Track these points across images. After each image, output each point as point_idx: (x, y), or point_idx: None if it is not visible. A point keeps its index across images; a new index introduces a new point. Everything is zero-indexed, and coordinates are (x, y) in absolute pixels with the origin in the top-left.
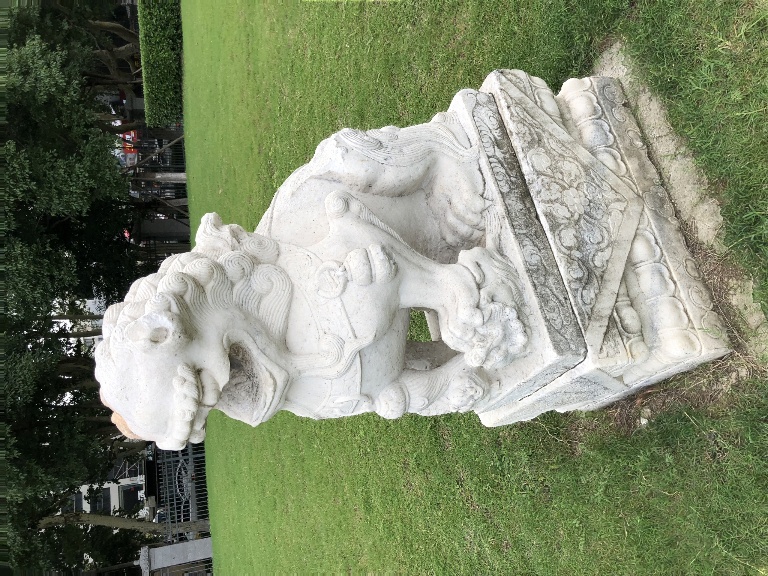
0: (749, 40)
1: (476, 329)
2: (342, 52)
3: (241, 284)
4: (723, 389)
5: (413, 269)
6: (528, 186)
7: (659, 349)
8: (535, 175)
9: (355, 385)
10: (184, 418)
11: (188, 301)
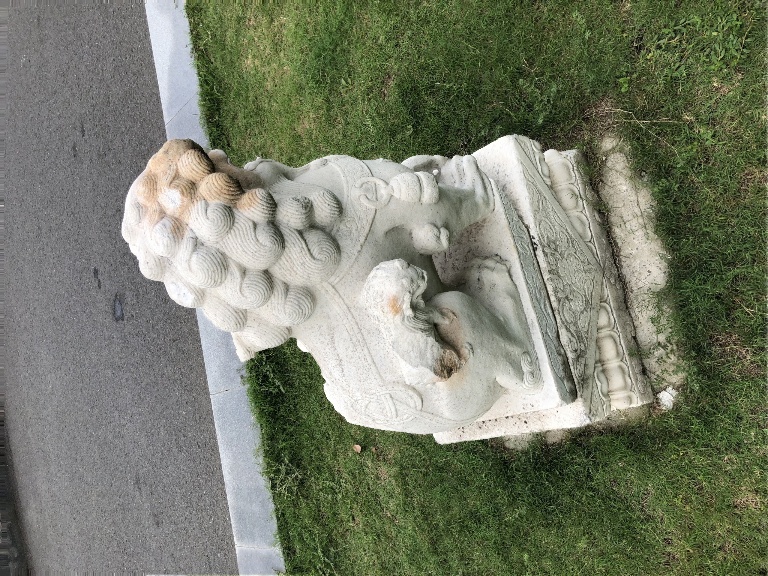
0: None
1: None
2: None
3: None
4: None
5: None
6: None
7: None
8: None
9: None
10: None
11: None
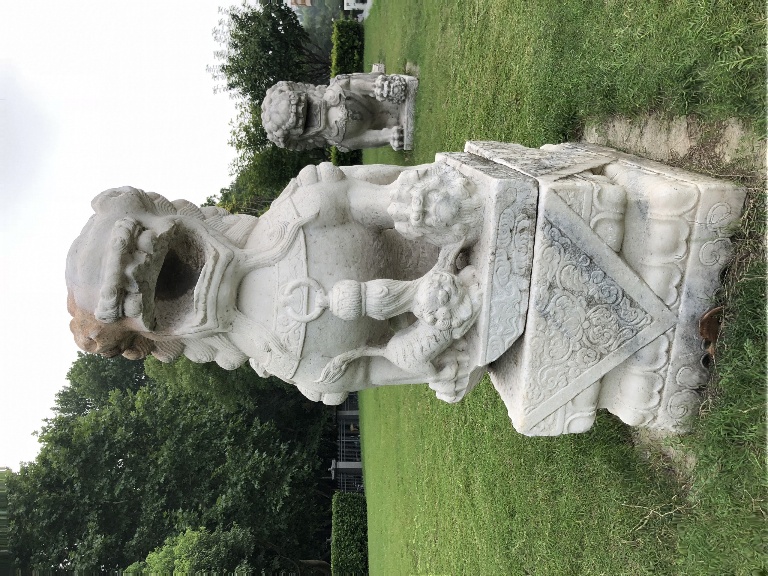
0: (633, 7)
1: (414, 186)
2: None
3: (212, 218)
4: (767, 239)
5: (363, 181)
6: (489, 159)
7: (650, 206)
8: (495, 153)
9: (301, 264)
10: (114, 244)
11: (156, 203)
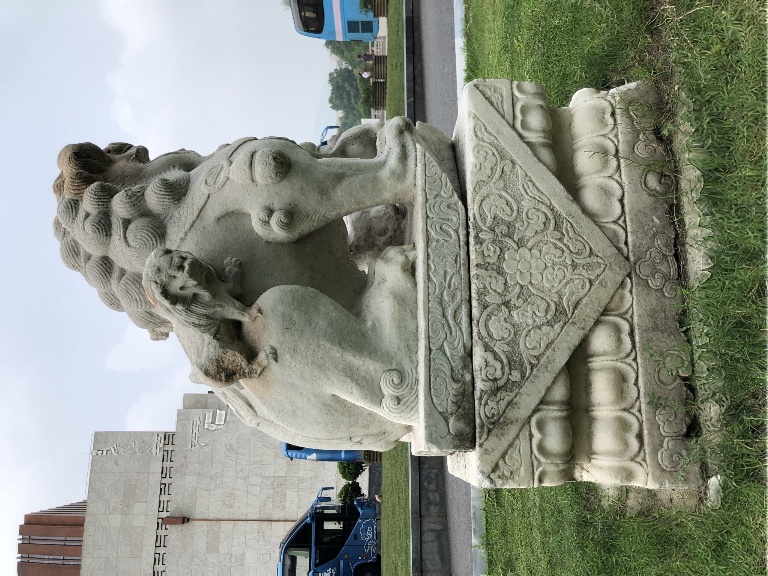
0: None
1: None
2: None
3: None
4: None
5: None
6: None
7: None
8: None
9: None
10: None
11: None
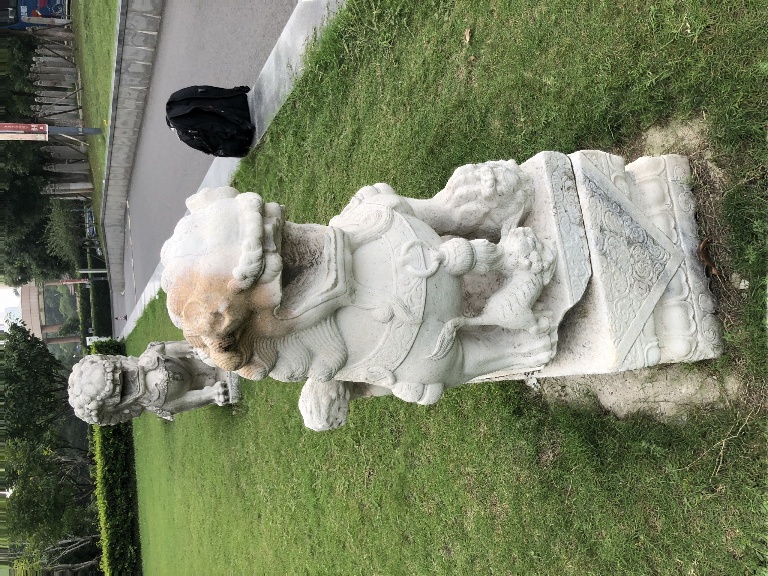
0: (527, 116)
1: None
2: (364, 571)
3: None
4: (719, 177)
5: None
6: None
7: (636, 174)
8: None
9: (407, 230)
10: (252, 202)
11: None
